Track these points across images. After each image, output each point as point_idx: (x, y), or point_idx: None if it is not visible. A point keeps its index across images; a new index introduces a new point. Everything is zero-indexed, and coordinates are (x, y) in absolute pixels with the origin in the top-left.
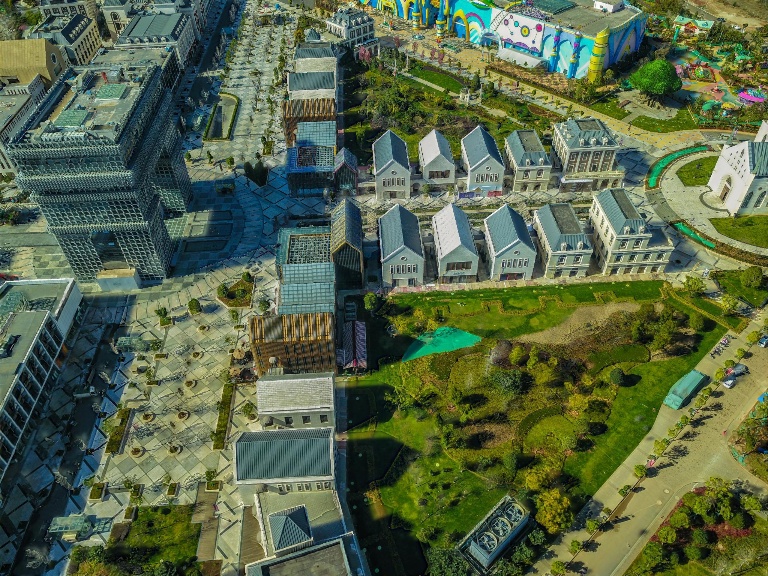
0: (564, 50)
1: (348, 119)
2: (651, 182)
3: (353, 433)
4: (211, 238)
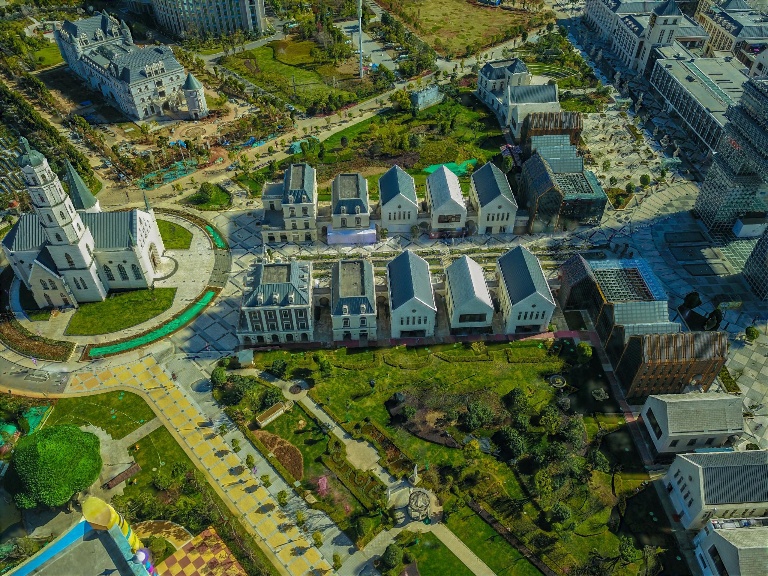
0: None
1: (632, 451)
2: (209, 297)
3: (500, 132)
4: (686, 244)
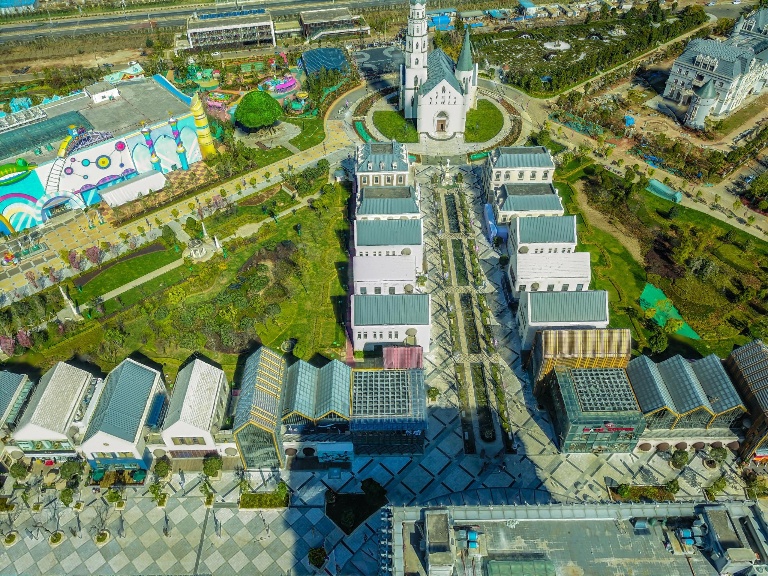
0: (161, 148)
1: None
2: None
3: None
4: None
